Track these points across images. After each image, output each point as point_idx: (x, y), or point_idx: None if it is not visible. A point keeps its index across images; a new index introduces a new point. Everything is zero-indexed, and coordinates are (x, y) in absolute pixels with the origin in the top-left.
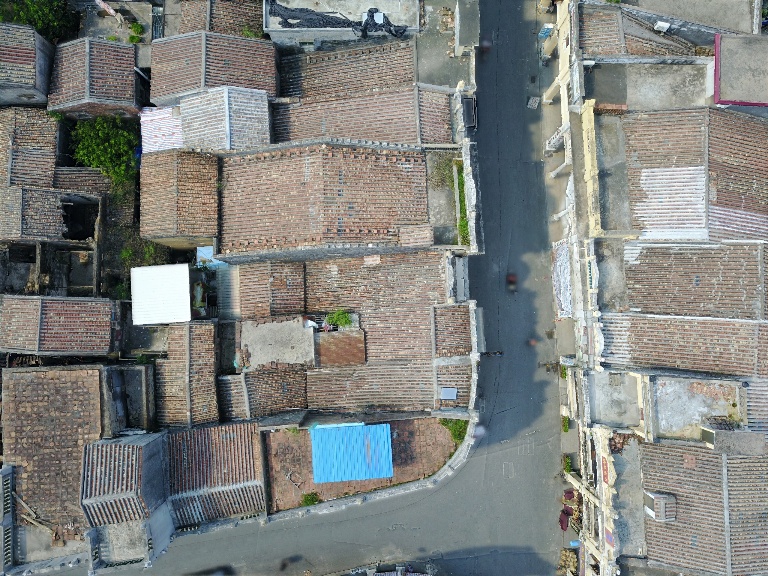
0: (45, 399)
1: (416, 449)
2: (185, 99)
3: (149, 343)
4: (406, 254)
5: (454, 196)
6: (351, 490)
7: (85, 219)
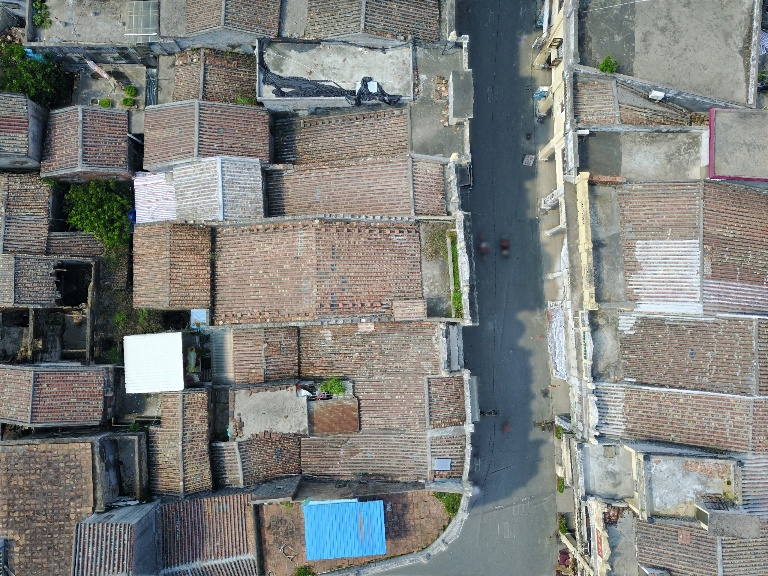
0: (37, 472)
1: (410, 522)
2: (178, 167)
3: (142, 408)
4: (400, 323)
5: (448, 267)
6: (344, 563)
7: (79, 279)
